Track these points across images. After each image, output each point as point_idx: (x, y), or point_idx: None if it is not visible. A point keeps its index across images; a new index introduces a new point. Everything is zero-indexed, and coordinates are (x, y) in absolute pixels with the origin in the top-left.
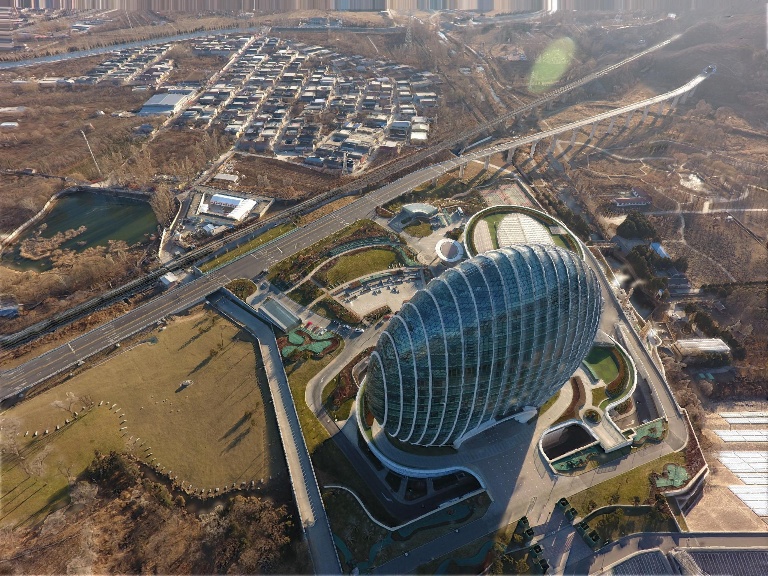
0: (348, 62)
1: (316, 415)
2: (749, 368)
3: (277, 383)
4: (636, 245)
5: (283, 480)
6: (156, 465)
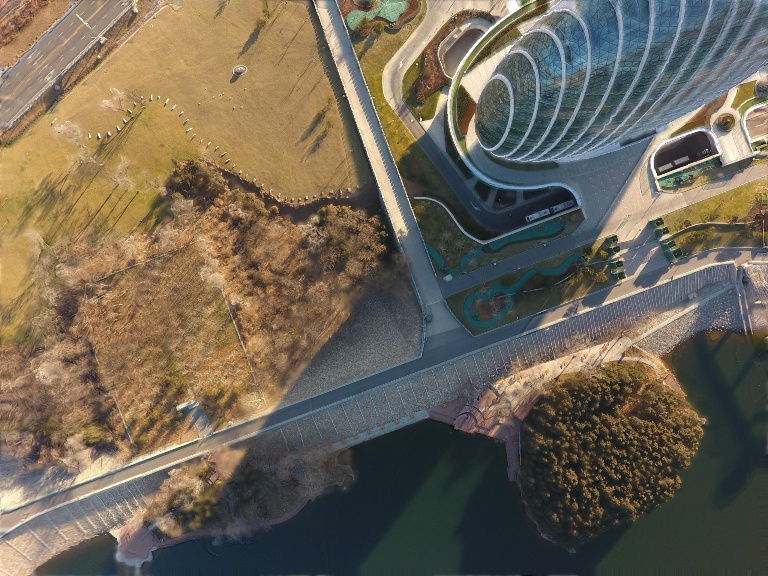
0: None
1: (397, 113)
2: None
3: (347, 69)
4: None
5: (371, 189)
6: (238, 172)
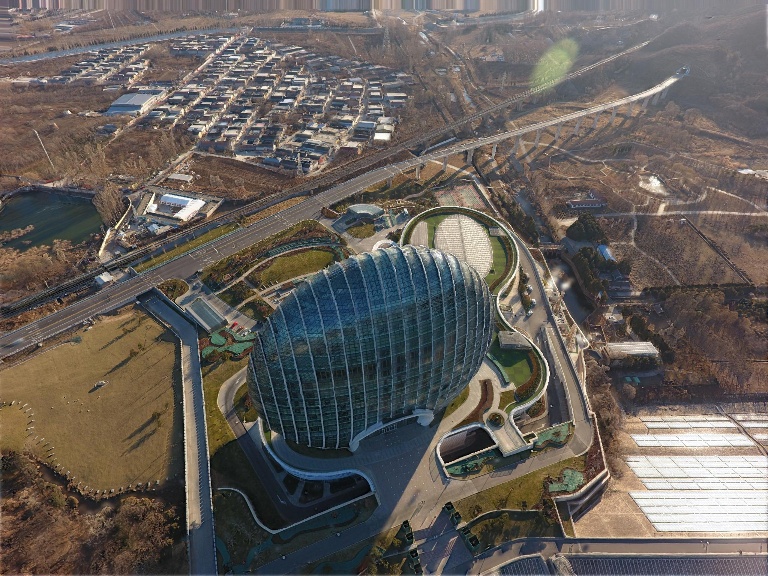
0: (323, 62)
1: (225, 416)
2: (677, 372)
3: (191, 384)
4: (582, 247)
5: (179, 481)
6: (56, 465)
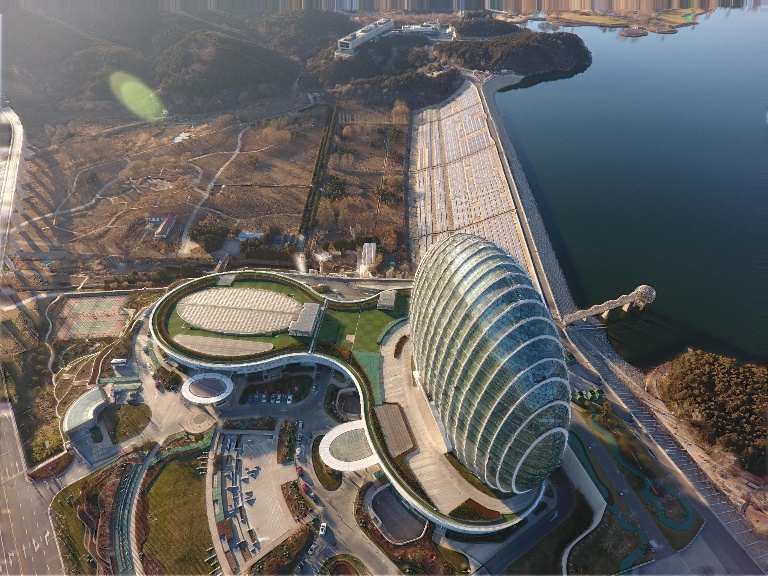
0: None
1: None
2: (389, 243)
3: None
4: (239, 245)
5: None
6: None
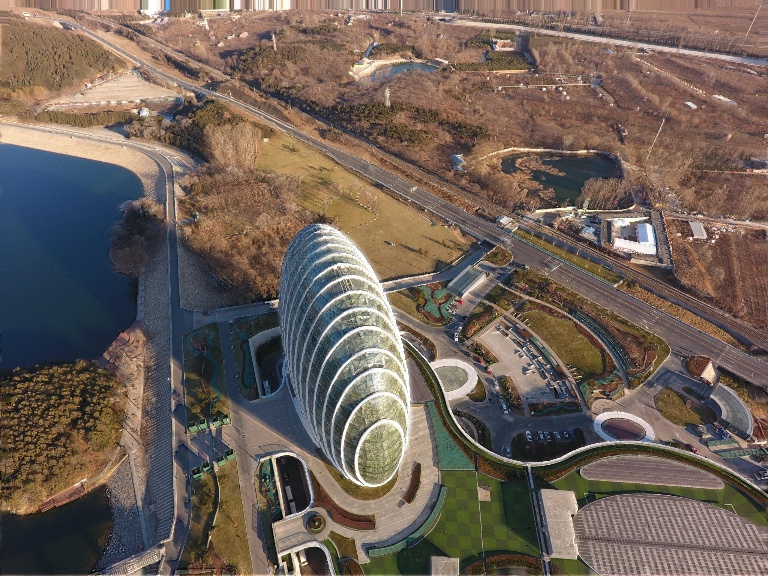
0: None
1: None
2: None
3: (391, 287)
4: None
5: None
6: None
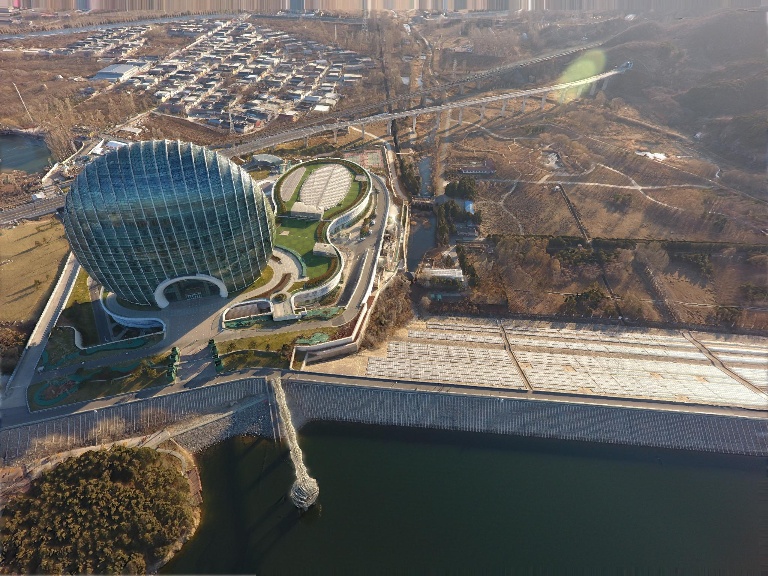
0: (299, 46)
1: (89, 288)
2: (474, 293)
3: (73, 266)
4: None
5: None
6: None
